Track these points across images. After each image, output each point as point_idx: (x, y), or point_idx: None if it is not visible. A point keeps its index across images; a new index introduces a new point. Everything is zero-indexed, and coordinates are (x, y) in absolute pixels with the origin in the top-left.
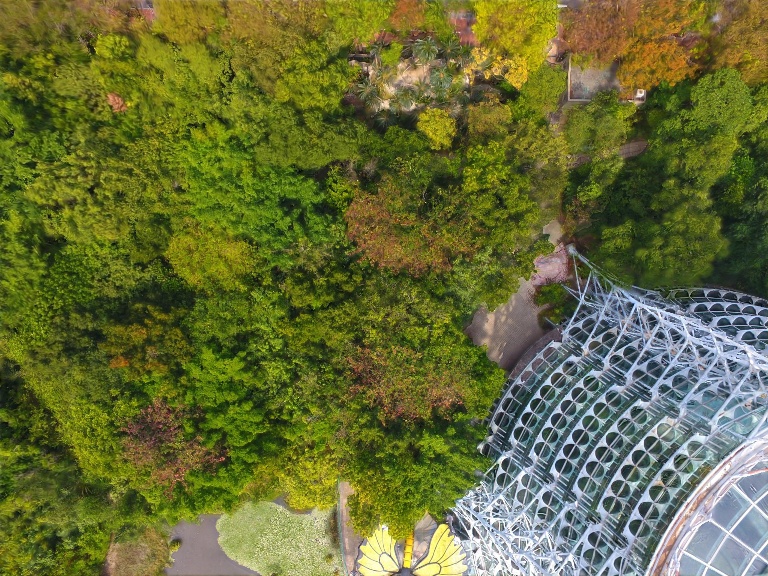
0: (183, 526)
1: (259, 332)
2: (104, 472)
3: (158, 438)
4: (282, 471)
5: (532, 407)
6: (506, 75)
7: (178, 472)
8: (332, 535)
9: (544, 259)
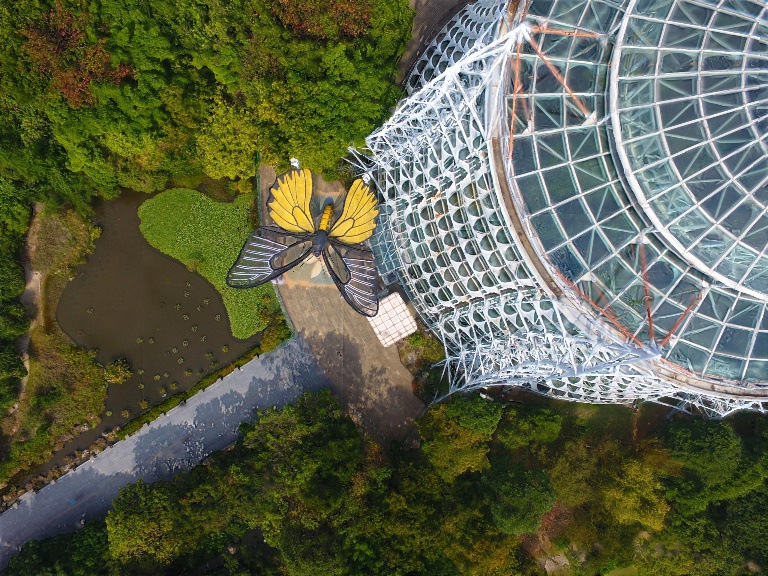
0: (105, 213)
1: None
2: (7, 82)
3: (61, 47)
4: (198, 132)
5: (443, 50)
6: None
7: (81, 82)
8: (252, 215)
9: None
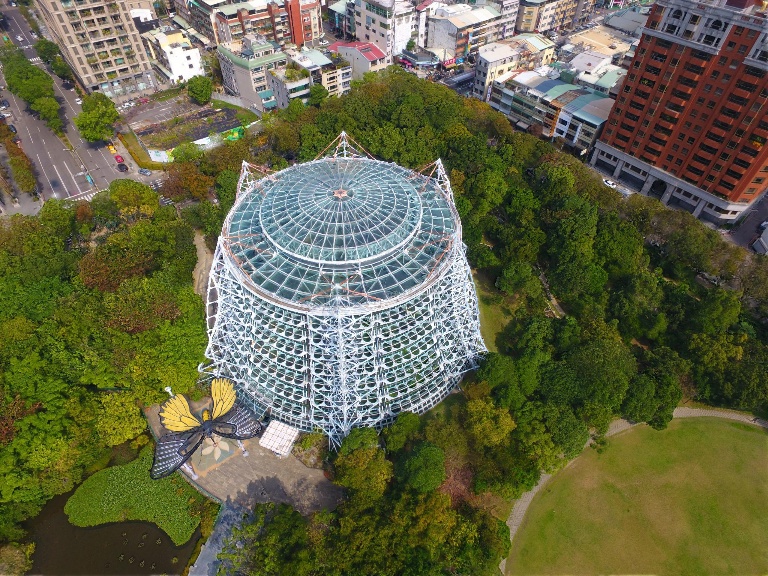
0: (35, 531)
1: (49, 349)
2: None
3: None
4: None
5: None
6: (140, 212)
7: (7, 426)
8: None
9: None
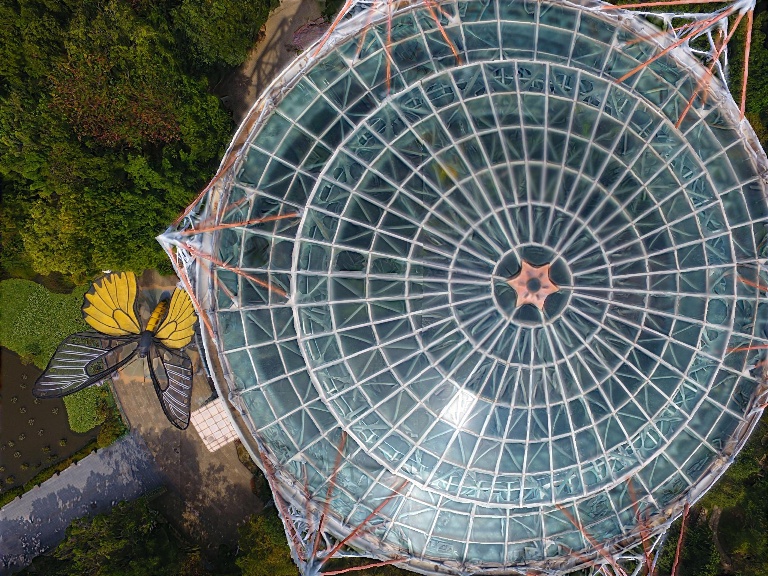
0: None
1: None
2: None
3: None
4: (21, 229)
5: None
6: None
7: None
8: None
9: (307, 30)
